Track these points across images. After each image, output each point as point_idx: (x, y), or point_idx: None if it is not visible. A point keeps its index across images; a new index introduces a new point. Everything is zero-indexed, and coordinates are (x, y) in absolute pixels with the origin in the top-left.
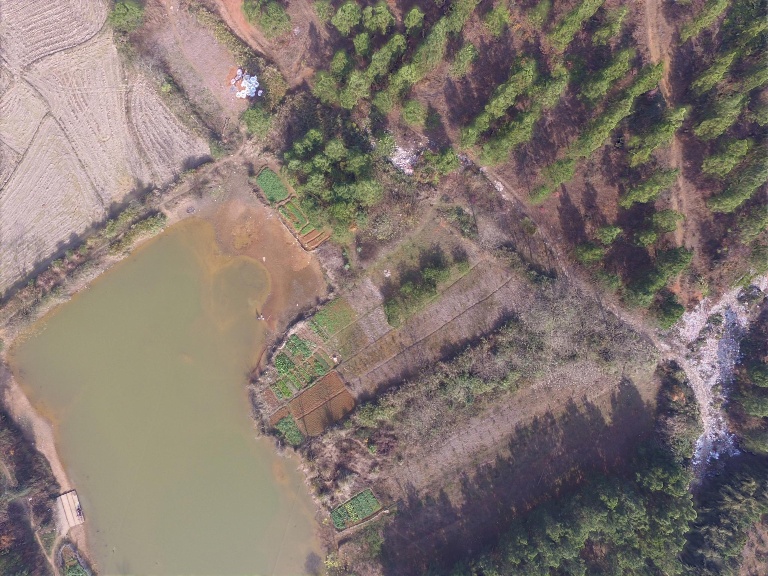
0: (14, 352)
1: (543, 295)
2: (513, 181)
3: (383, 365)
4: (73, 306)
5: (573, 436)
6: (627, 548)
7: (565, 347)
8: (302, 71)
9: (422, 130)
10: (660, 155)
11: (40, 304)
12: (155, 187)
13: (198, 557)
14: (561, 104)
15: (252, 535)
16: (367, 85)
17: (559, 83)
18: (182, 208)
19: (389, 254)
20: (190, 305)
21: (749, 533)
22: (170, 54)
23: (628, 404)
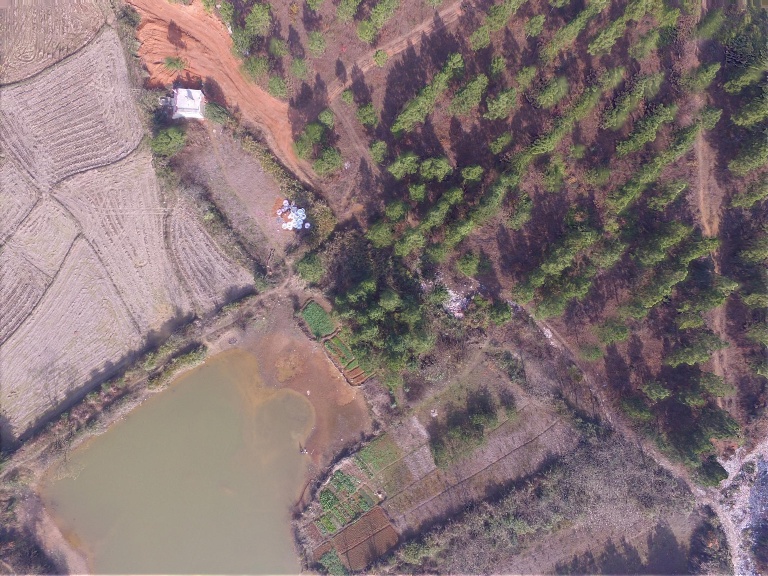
0: (45, 483)
1: (587, 441)
2: (562, 329)
3: (428, 503)
4: (109, 438)
5: (610, 574)
6: None
7: (606, 490)
8: (352, 206)
9: (473, 274)
10: (705, 312)
11: (74, 438)
12: (196, 317)
13: None
14: None
15: None
16: (425, 239)
17: (617, 251)
18: (224, 339)
19: (436, 394)
20: (231, 437)
21: None
22: (212, 179)
23: (664, 545)
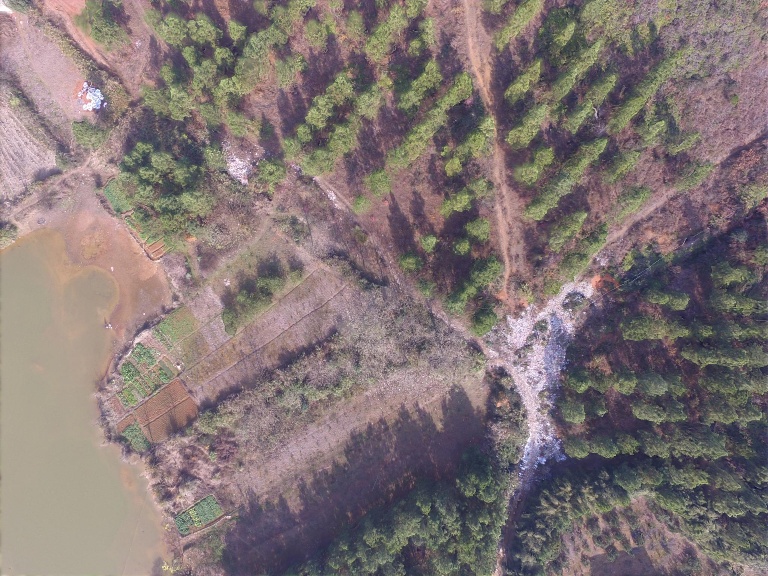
0: None
1: (374, 303)
2: (344, 190)
3: (224, 373)
4: None
5: (406, 442)
6: (444, 553)
7: (397, 354)
8: (144, 83)
9: (257, 141)
10: (483, 163)
11: None
12: (7, 199)
13: (50, 562)
14: (388, 114)
15: (101, 540)
16: (191, 98)
17: (370, 94)
18: (33, 219)
19: (228, 263)
20: (42, 315)
21: (575, 538)
22: (20, 68)
23: (458, 410)
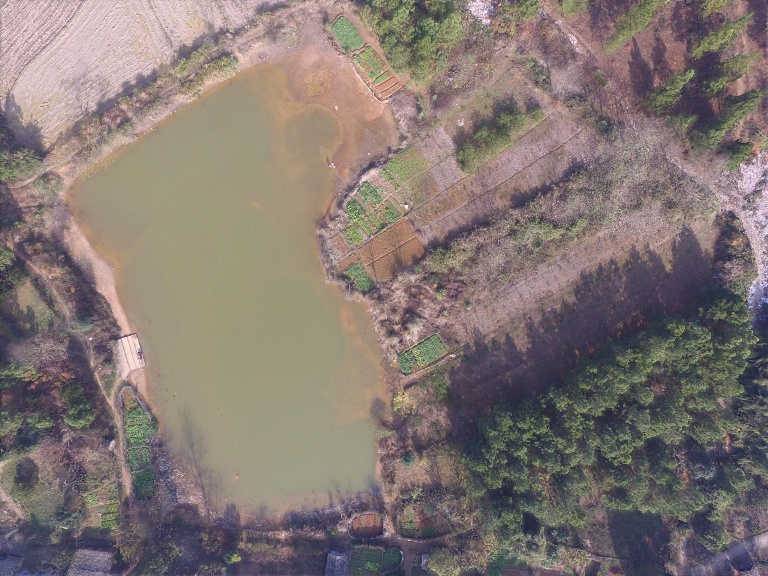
0: (74, 193)
1: (612, 145)
2: (587, 35)
3: (454, 213)
4: (139, 147)
5: (635, 282)
6: (690, 376)
7: (631, 197)
8: None
9: None
10: (727, 13)
11: (105, 142)
12: (227, 31)
13: (262, 402)
14: None
15: (317, 381)
16: None
17: None
18: (254, 53)
19: (463, 104)
20: (260, 151)
21: None
22: None
23: (688, 252)
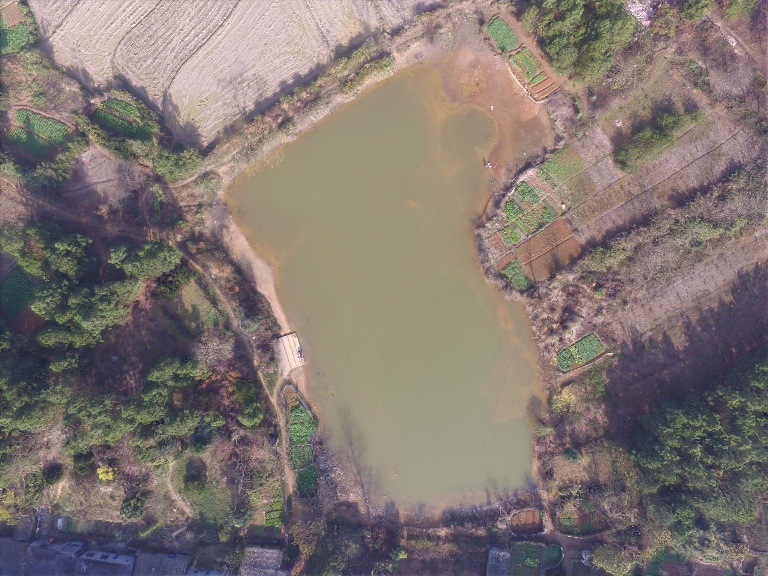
0: (232, 192)
1: None
2: (746, 36)
3: (611, 212)
4: (297, 146)
5: None
6: None
7: None
8: None
9: None
10: None
11: (266, 141)
12: (384, 31)
13: (419, 400)
14: None
15: (474, 379)
16: None
17: None
18: (411, 53)
19: (621, 104)
20: (416, 151)
21: None
22: None
23: None
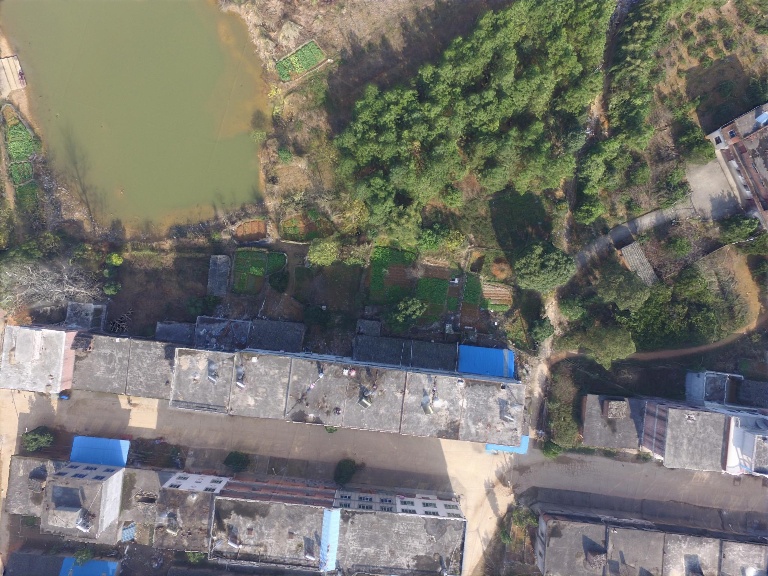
0: None
1: None
2: None
3: None
4: None
5: None
6: None
7: None
8: None
9: None
10: None
11: None
12: None
13: (144, 119)
14: None
15: (198, 96)
16: None
17: None
18: None
19: None
20: None
21: (671, 53)
22: None
23: None
